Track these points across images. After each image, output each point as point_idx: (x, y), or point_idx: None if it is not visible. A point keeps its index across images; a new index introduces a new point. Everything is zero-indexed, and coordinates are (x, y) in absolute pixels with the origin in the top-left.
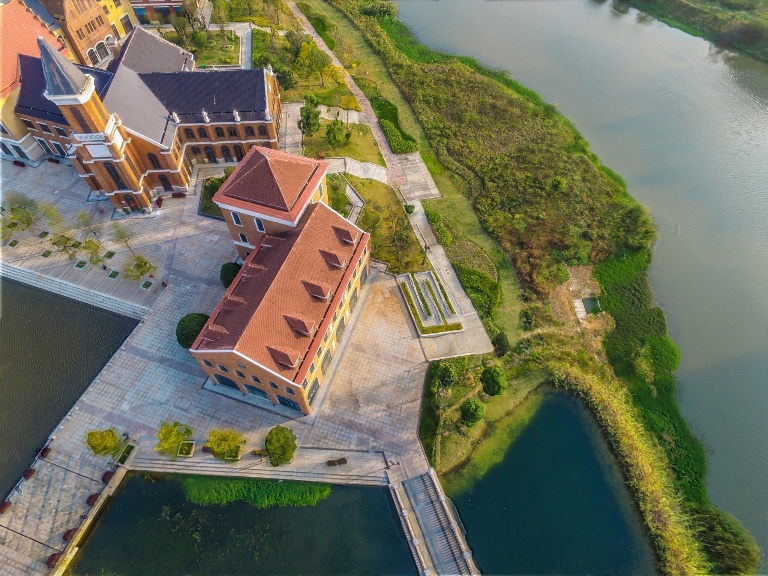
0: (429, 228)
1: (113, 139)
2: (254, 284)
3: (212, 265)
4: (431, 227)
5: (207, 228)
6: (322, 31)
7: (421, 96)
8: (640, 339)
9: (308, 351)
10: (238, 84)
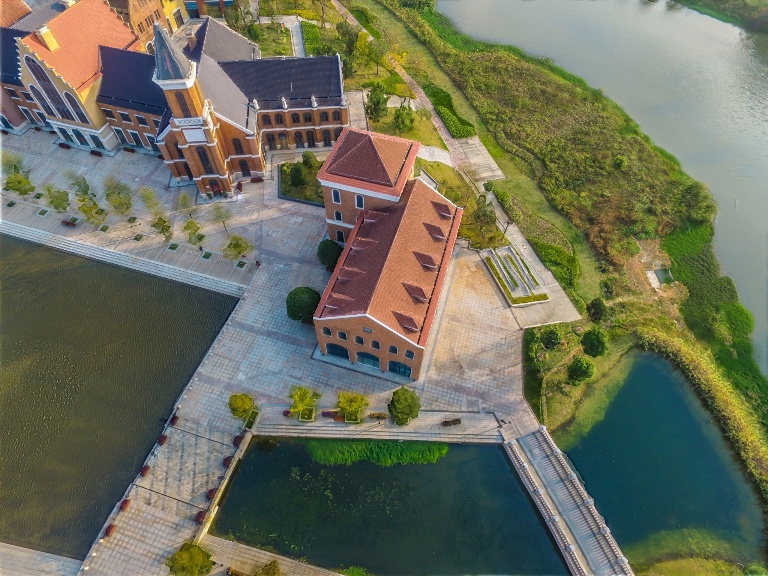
0: (499, 207)
1: (209, 123)
2: (367, 255)
3: (300, 245)
4: (501, 206)
5: (289, 210)
6: (366, 23)
7: (472, 83)
8: (714, 306)
9: (426, 316)
10: (314, 71)
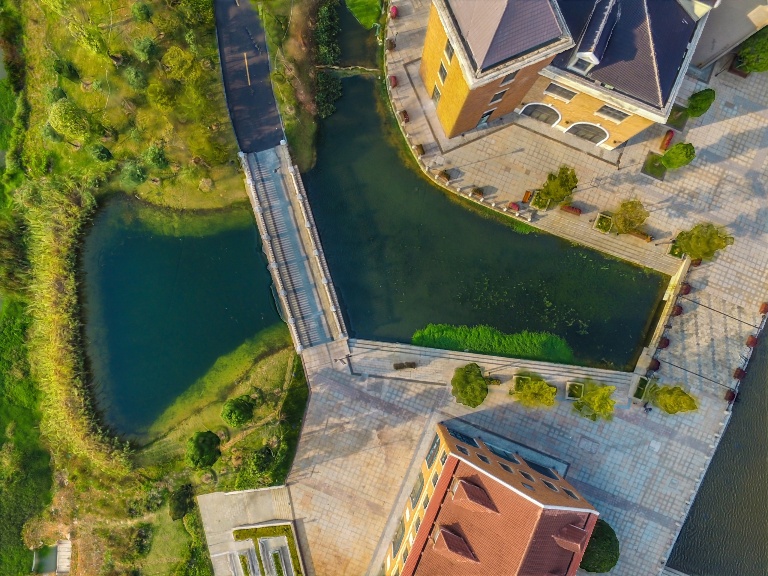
0: None
1: None
2: None
3: None
4: None
5: None
6: None
7: None
8: None
9: (442, 504)
10: None
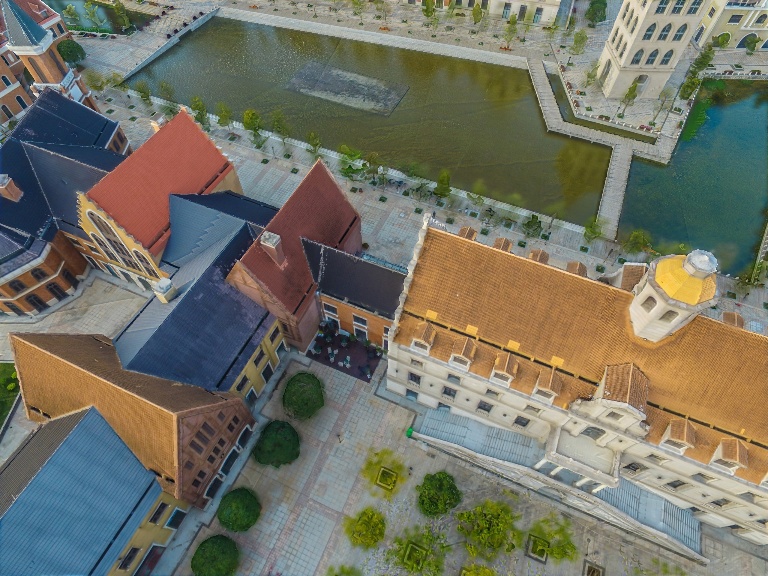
0: None
1: None
2: (2, 19)
3: None
4: None
5: None
6: None
7: None
8: None
9: None
10: None
